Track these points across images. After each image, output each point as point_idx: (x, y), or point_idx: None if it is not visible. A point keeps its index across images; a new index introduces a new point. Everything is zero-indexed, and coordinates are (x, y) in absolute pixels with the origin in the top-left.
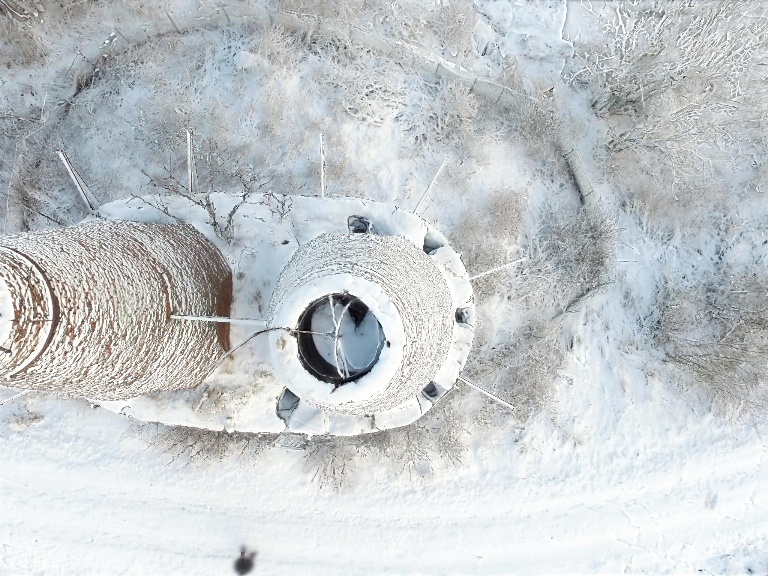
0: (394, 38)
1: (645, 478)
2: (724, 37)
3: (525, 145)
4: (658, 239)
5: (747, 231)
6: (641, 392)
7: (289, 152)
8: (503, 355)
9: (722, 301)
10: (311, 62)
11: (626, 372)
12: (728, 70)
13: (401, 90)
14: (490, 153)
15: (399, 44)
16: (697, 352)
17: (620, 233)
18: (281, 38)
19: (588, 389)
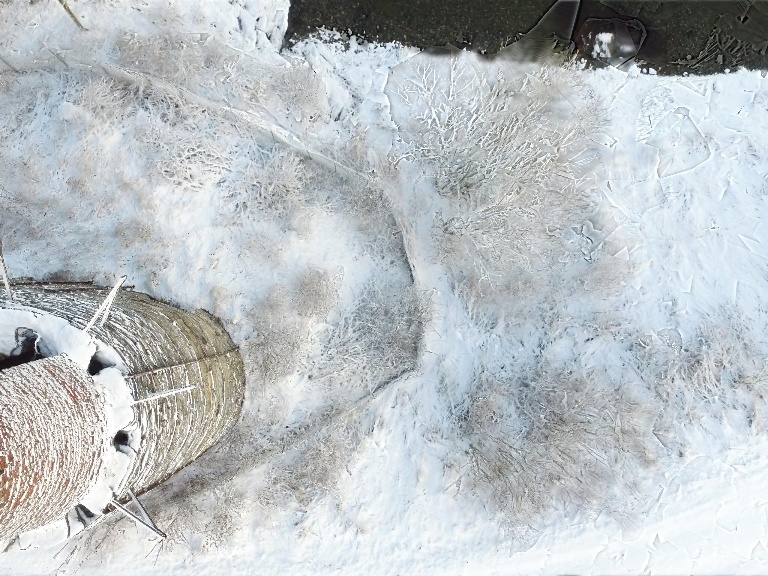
0: (222, 103)
1: (424, 573)
2: (529, 143)
3: (359, 218)
4: (482, 326)
5: (572, 326)
6: (436, 483)
7: (98, 210)
8: (294, 435)
9: (533, 397)
10: (139, 118)
11: (425, 461)
12: (534, 175)
13: (226, 156)
14: (318, 225)
15: (227, 109)
16: (499, 447)
17: (446, 316)
18: (108, 92)
19: (382, 475)
